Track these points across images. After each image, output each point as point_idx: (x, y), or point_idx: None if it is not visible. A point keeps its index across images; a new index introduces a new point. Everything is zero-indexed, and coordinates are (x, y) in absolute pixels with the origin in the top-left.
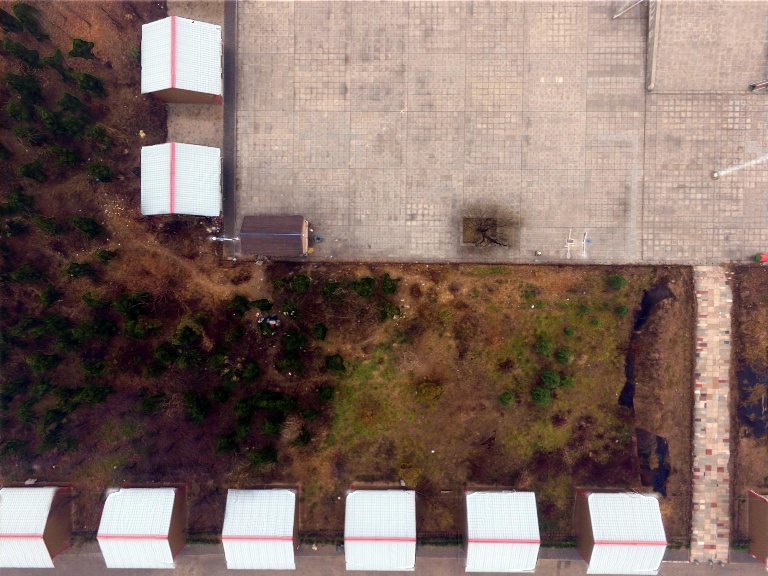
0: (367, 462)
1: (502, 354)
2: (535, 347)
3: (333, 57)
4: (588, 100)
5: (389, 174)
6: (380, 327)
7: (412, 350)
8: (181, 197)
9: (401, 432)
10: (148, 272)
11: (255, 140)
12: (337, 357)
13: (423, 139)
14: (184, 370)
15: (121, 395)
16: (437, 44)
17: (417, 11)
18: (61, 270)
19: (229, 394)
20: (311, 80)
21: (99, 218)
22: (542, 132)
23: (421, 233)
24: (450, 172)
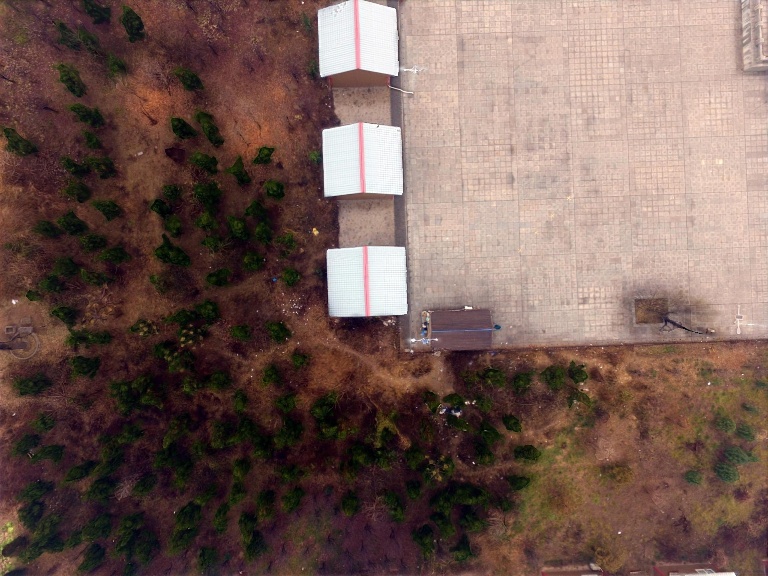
0: (554, 547)
1: (682, 432)
2: (716, 424)
3: (499, 148)
4: (748, 180)
5: (559, 259)
6: (561, 412)
7: (594, 433)
8: (375, 299)
9: (587, 515)
10: (330, 370)
11: (426, 232)
12: (535, 449)
13: (591, 224)
14: (385, 472)
15: (307, 495)
16: (599, 132)
17: (578, 101)
18: (240, 372)
19: (419, 489)
20: (478, 171)
21: (277, 318)
22: (706, 212)
23: (594, 316)
24: (619, 255)
